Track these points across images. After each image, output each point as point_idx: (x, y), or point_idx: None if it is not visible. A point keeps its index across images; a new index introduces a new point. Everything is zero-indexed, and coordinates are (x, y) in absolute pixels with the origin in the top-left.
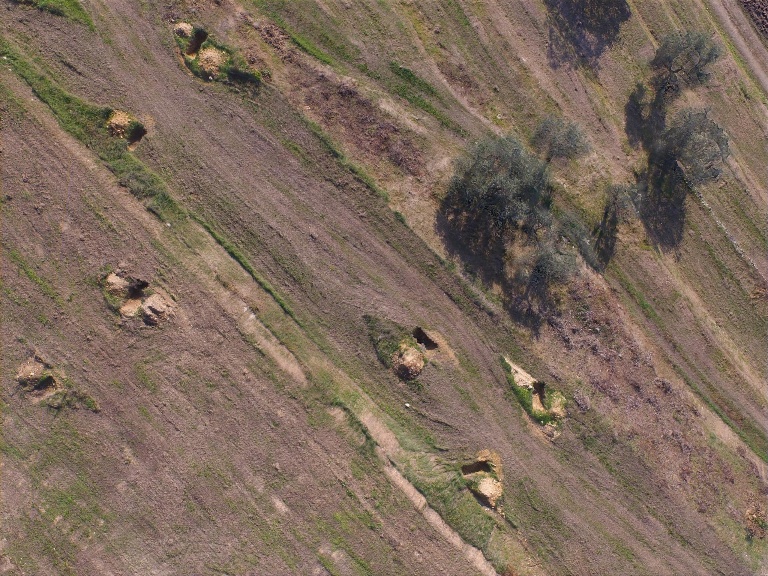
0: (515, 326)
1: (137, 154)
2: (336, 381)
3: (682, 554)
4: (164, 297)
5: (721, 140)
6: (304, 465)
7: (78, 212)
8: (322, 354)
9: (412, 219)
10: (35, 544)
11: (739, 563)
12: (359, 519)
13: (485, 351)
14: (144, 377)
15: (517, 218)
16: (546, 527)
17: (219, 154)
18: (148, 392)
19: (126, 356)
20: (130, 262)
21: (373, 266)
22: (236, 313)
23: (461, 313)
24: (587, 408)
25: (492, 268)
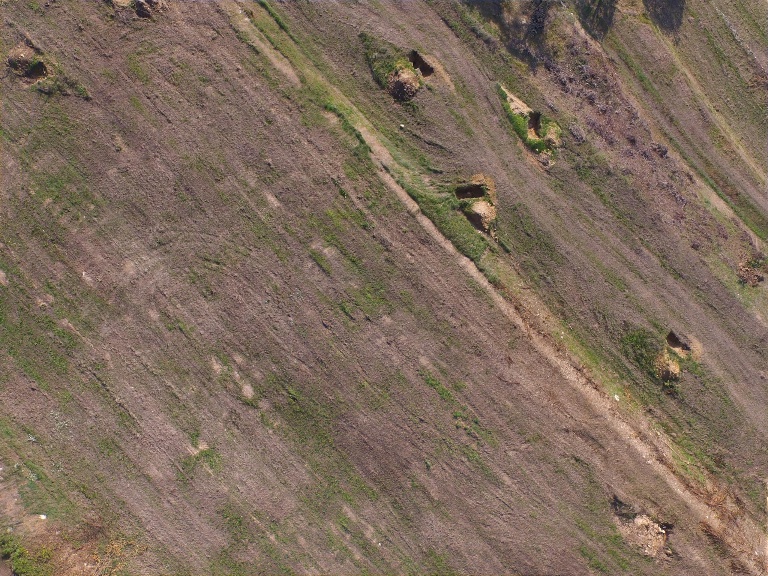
0: (512, 57)
1: None
2: (330, 94)
3: (674, 287)
4: None
5: None
6: (297, 163)
7: None
8: (317, 70)
9: None
10: (24, 225)
11: (731, 298)
12: (351, 218)
13: (481, 78)
14: (136, 68)
15: None
16: (539, 253)
17: None
18: (140, 83)
19: (118, 47)
20: None
21: None
22: (230, 11)
23: (458, 40)
24: (582, 139)
25: (490, 10)
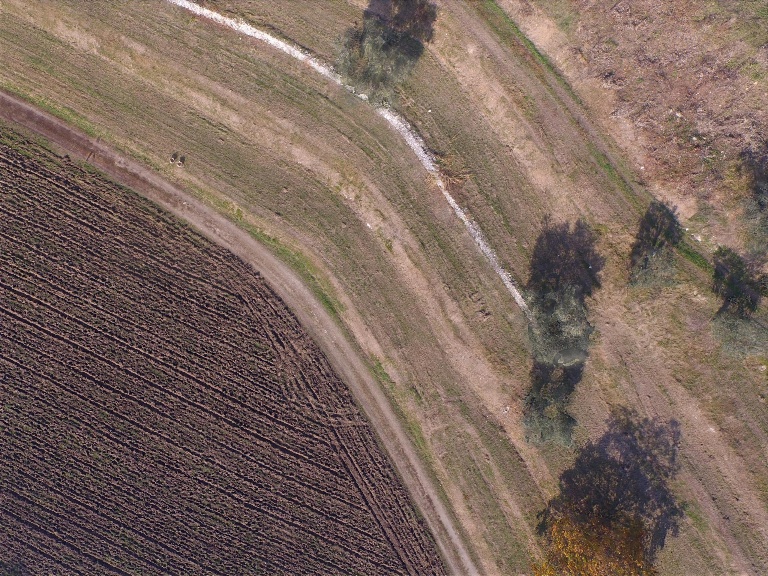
0: None
1: None
2: None
3: None
4: None
5: None
6: None
7: None
8: None
9: None
10: None
11: None
12: None
13: None
14: None
15: None
16: None
17: None
18: None
19: None
20: None
21: None
22: None
23: None
24: (765, 48)
25: None
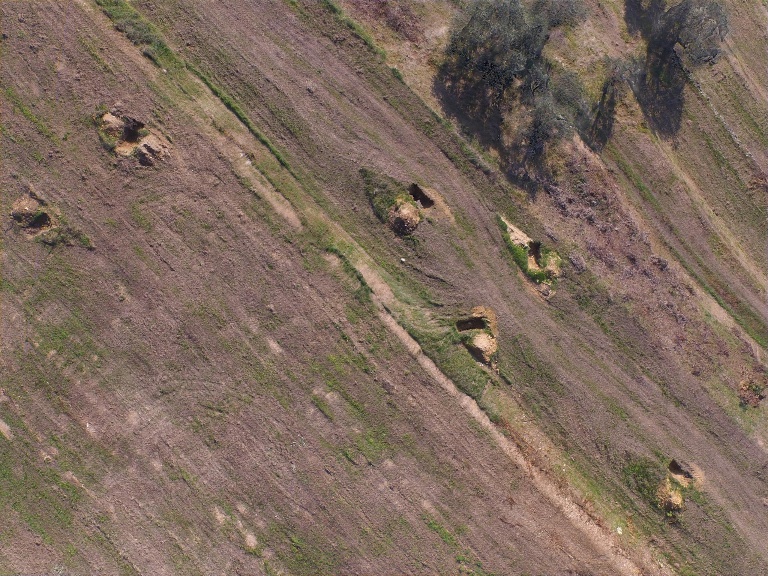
0: (511, 186)
1: (134, 4)
2: (332, 232)
3: (676, 414)
4: (160, 138)
5: (720, 16)
6: (299, 308)
7: (74, 52)
8: (318, 207)
9: (409, 79)
10: (29, 377)
11: (732, 425)
12: (353, 362)
13: (481, 209)
14: (139, 217)
15: (514, 69)
16: (540, 384)
17: (216, 7)
18: (143, 232)
19: (121, 196)
20: (126, 103)
21: (370, 122)
22: (232, 157)
23: (457, 172)
24: (582, 268)
25: (489, 134)
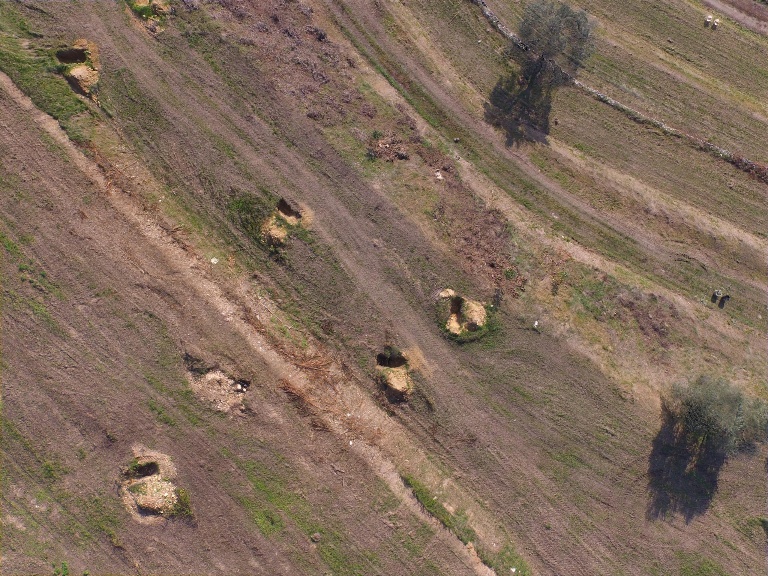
0: None
1: None
2: None
3: (286, 154)
4: None
5: None
6: None
7: None
8: None
9: None
10: None
11: (345, 166)
12: None
13: None
14: None
15: None
16: (143, 118)
17: None
18: None
19: None
20: None
21: None
22: None
23: None
24: (193, 6)
25: None
